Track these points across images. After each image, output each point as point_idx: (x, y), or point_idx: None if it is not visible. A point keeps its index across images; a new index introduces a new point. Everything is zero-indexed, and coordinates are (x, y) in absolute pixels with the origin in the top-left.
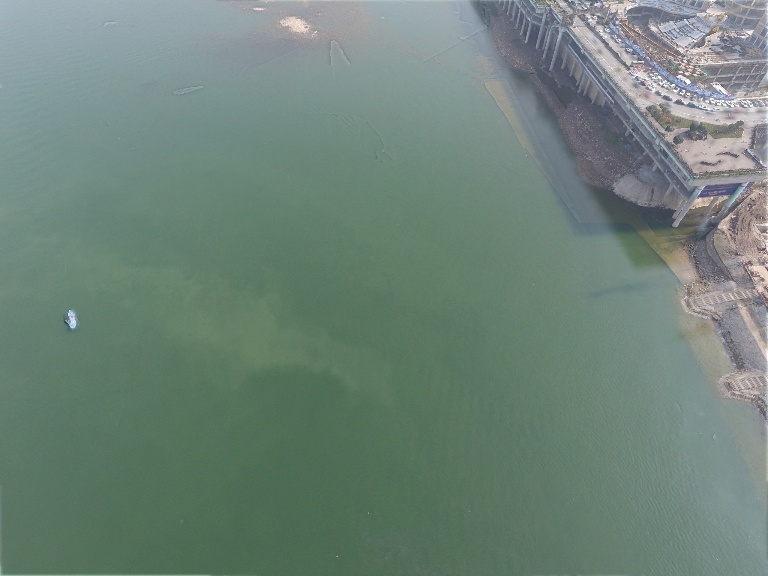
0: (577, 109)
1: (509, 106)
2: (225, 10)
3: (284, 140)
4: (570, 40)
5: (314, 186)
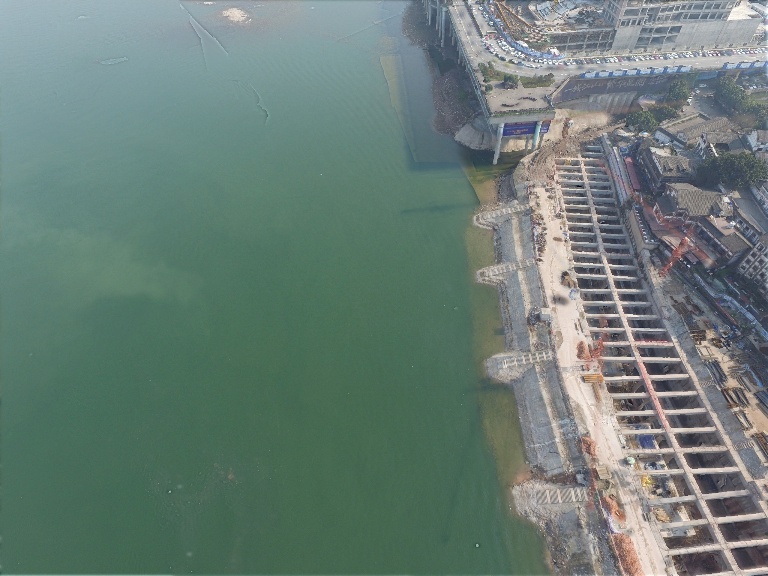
0: (447, 75)
1: (394, 75)
2: None
3: (193, 102)
4: None
5: (208, 137)
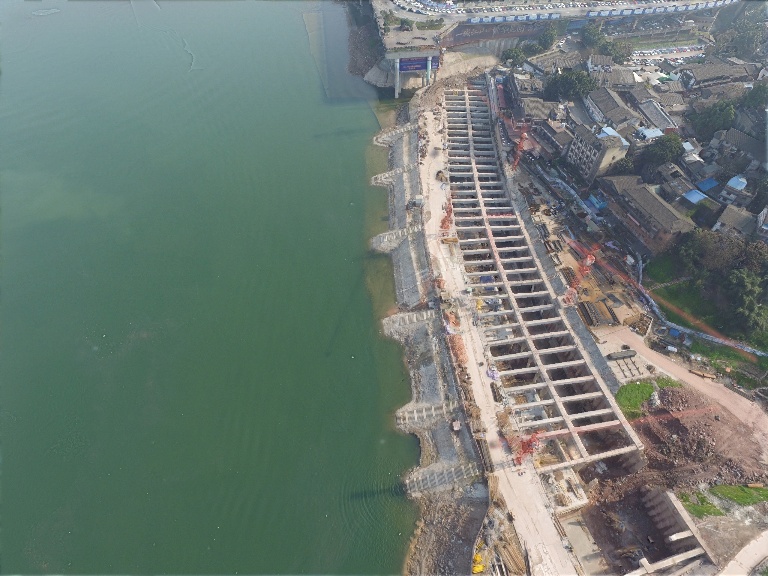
0: None
1: (314, 29)
2: None
3: (125, 51)
4: None
5: (140, 81)
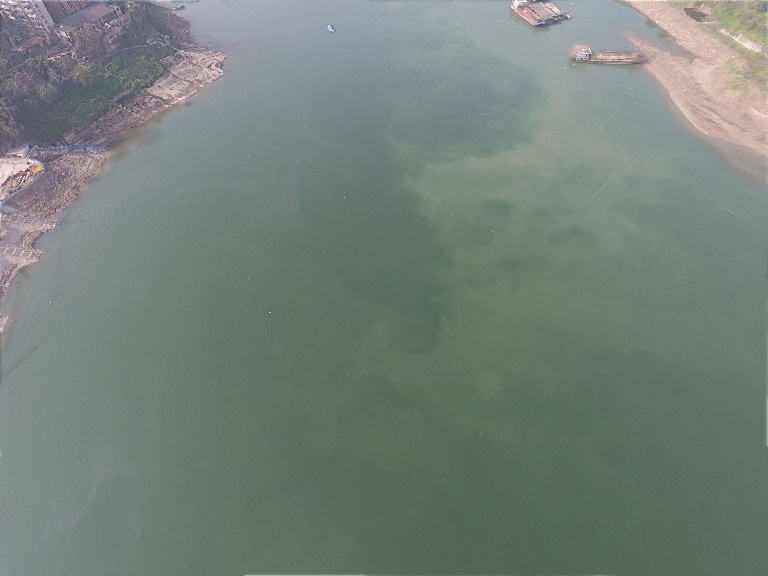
0: None
1: None
2: None
3: None
4: None
5: None
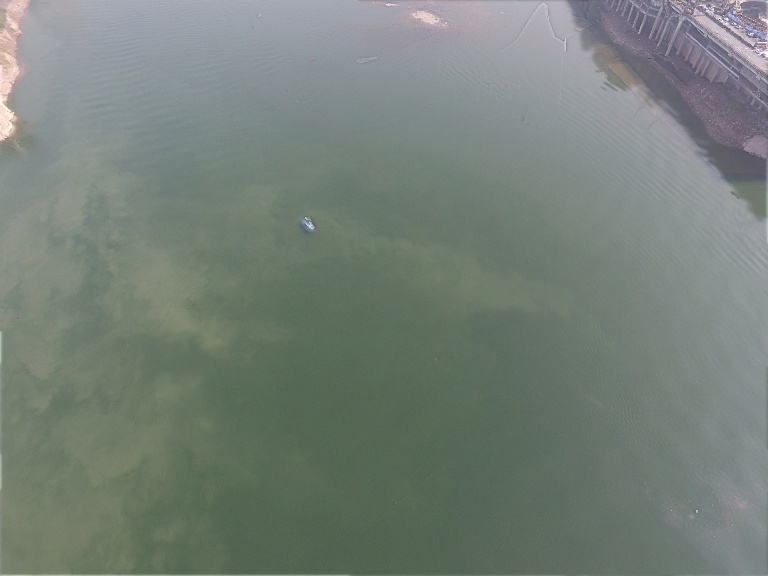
0: (700, 85)
1: (634, 83)
2: (361, 5)
3: (443, 104)
4: (688, 28)
5: (475, 140)
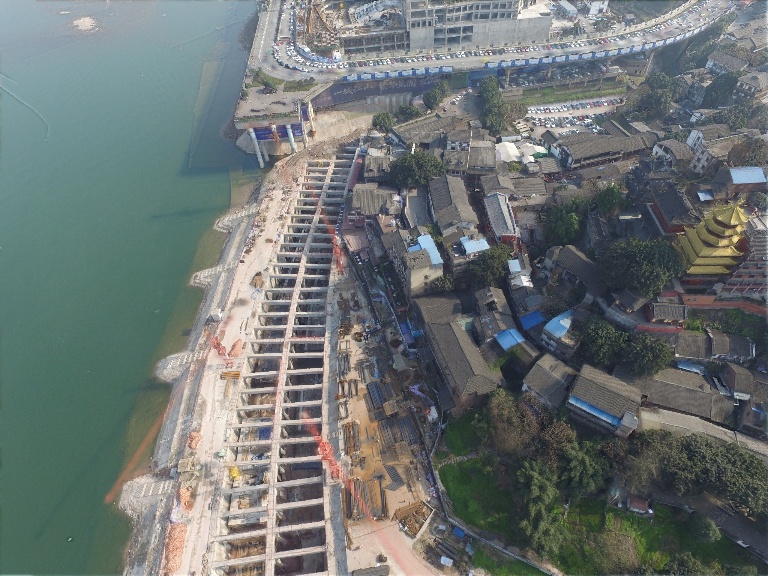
0: None
1: (209, 81)
2: (36, 15)
3: (1, 114)
4: None
5: (5, 148)
